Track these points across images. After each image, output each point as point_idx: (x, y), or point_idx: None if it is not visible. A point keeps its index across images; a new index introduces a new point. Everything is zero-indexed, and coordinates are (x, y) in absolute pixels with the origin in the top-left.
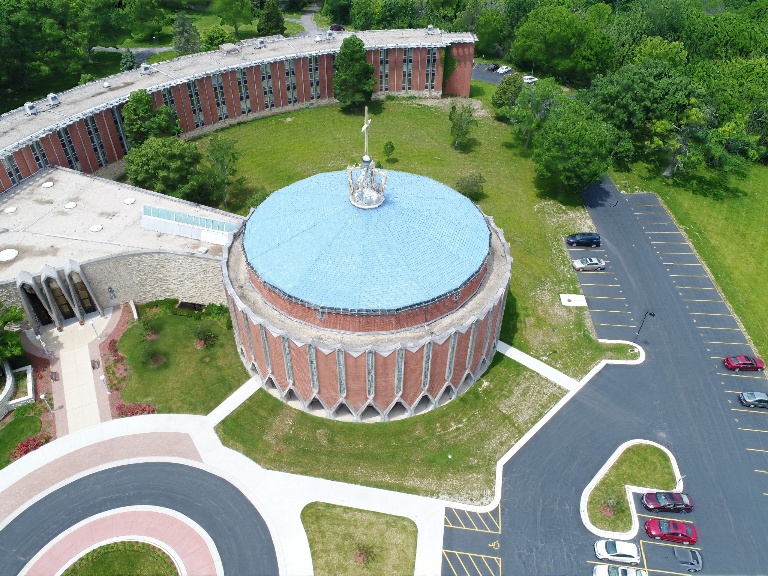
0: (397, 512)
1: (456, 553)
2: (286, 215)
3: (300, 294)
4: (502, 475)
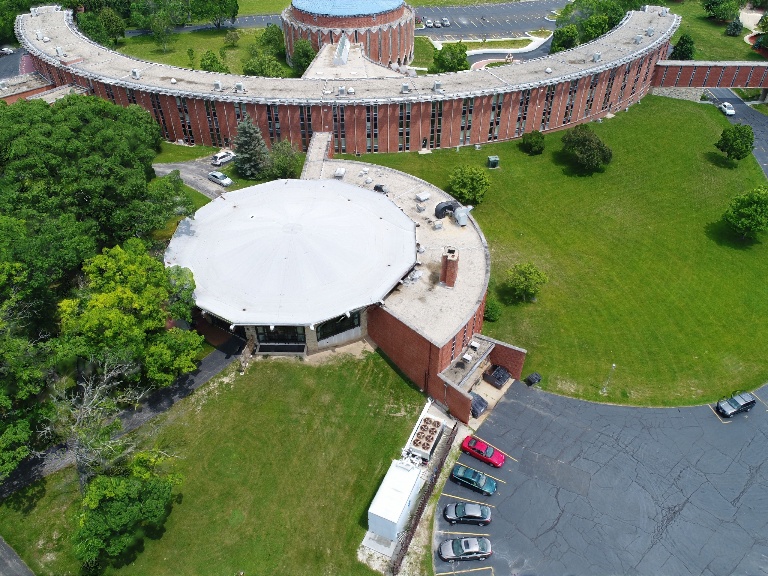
0: (441, 45)
1: (447, 39)
2: (356, 3)
3: (401, 2)
4: (415, 36)
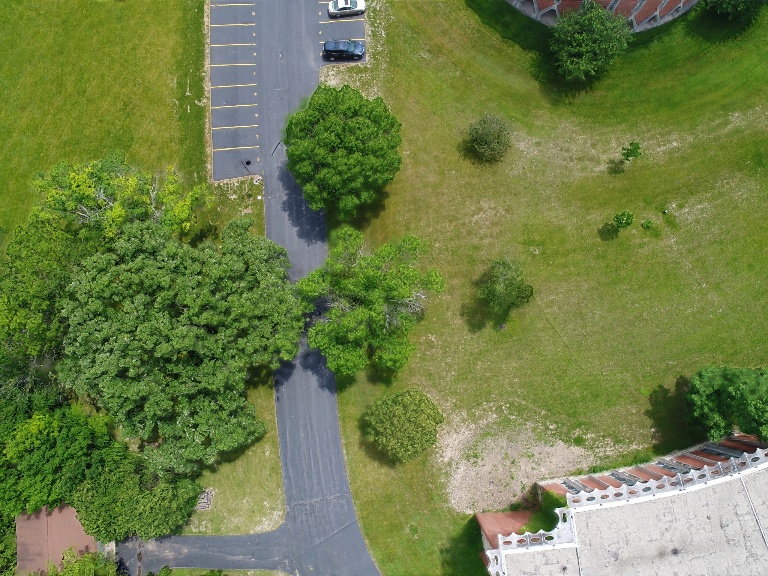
0: None
1: None
2: None
3: None
4: None
